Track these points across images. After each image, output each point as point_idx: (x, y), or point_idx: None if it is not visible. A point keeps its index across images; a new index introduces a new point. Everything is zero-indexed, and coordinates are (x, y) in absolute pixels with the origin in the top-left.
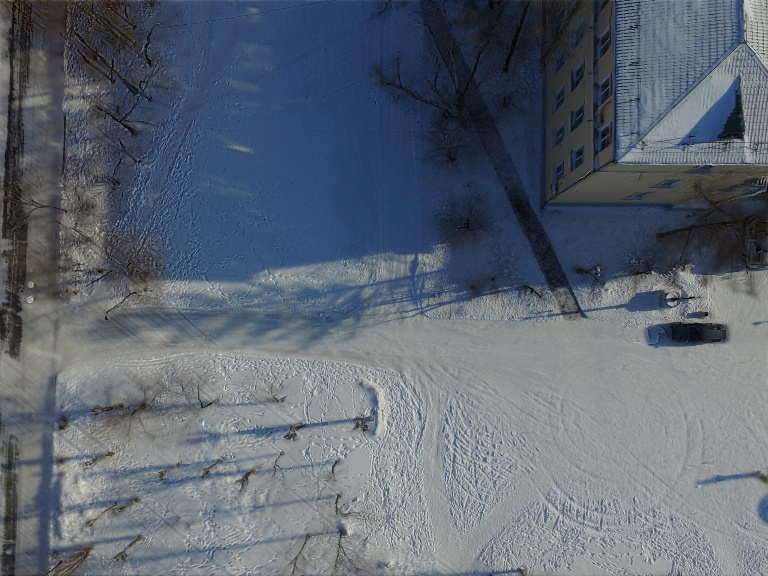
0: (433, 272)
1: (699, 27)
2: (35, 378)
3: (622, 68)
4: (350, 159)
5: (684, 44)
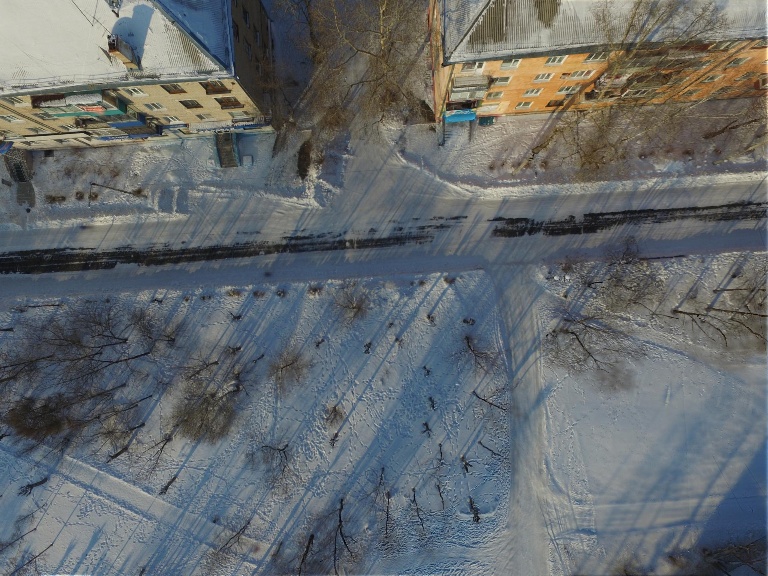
0: (583, 547)
1: None
2: (479, 251)
3: None
4: (666, 479)
5: None
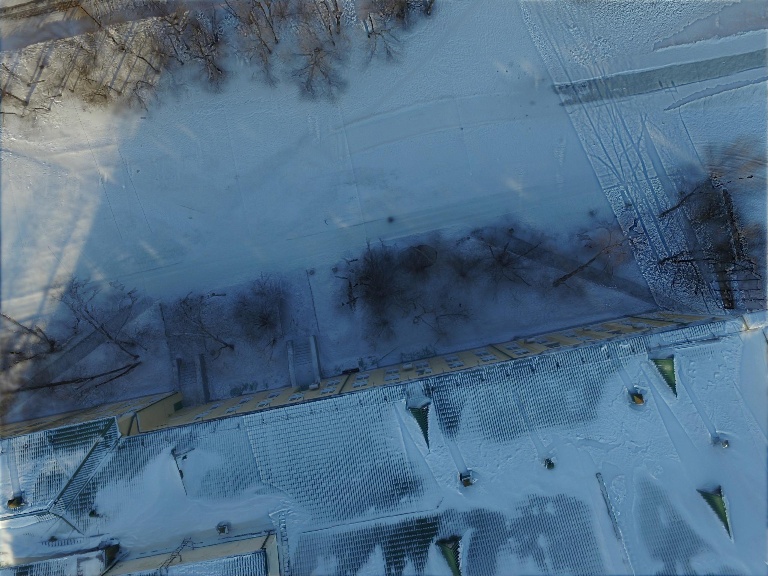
0: None
1: None
2: None
3: None
4: (8, 277)
5: None
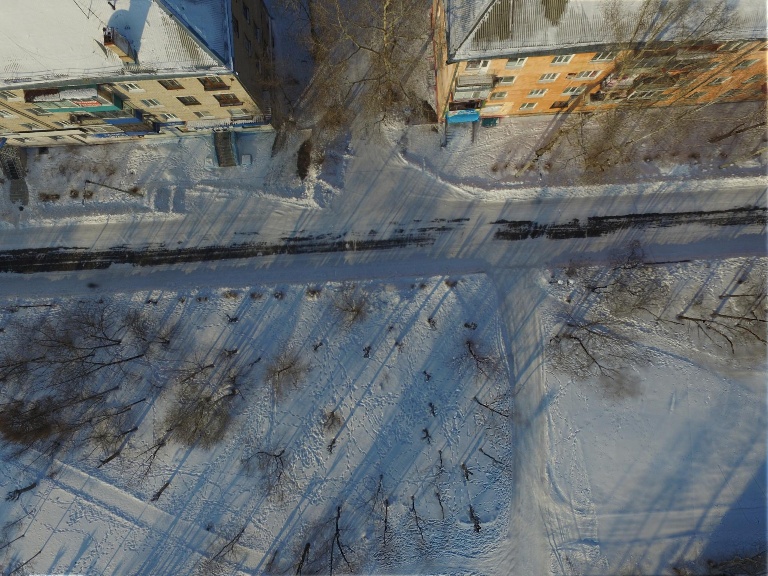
0: (586, 558)
1: None
2: (481, 254)
3: None
4: (670, 489)
5: None
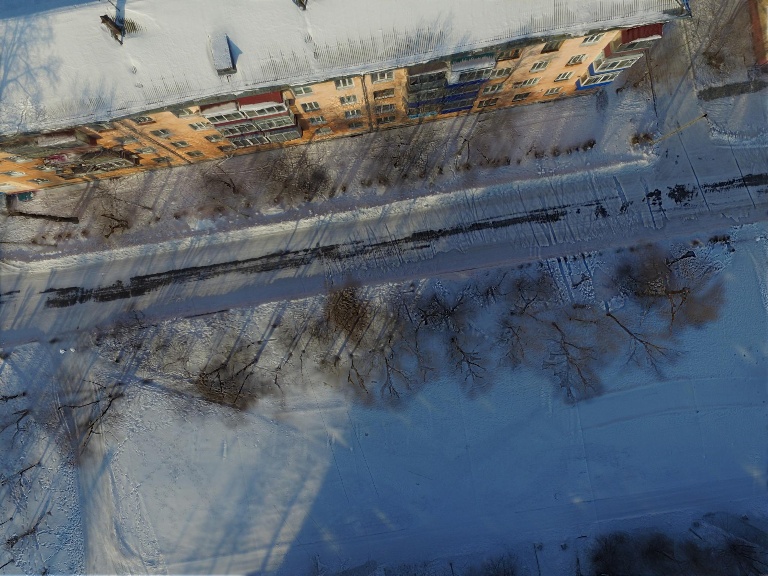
0: None
1: None
2: (34, 324)
3: None
4: (232, 533)
5: None
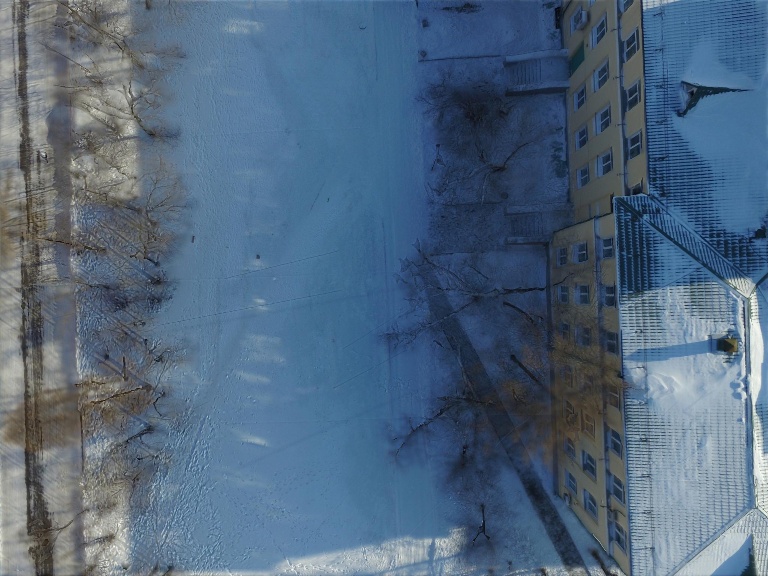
0: (451, 557)
1: (710, 485)
2: None
3: (635, 515)
4: (363, 448)
5: (696, 500)
